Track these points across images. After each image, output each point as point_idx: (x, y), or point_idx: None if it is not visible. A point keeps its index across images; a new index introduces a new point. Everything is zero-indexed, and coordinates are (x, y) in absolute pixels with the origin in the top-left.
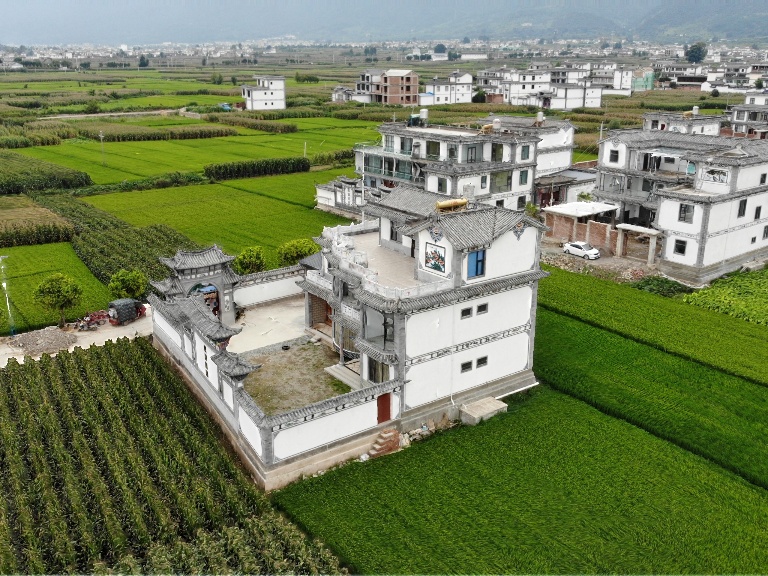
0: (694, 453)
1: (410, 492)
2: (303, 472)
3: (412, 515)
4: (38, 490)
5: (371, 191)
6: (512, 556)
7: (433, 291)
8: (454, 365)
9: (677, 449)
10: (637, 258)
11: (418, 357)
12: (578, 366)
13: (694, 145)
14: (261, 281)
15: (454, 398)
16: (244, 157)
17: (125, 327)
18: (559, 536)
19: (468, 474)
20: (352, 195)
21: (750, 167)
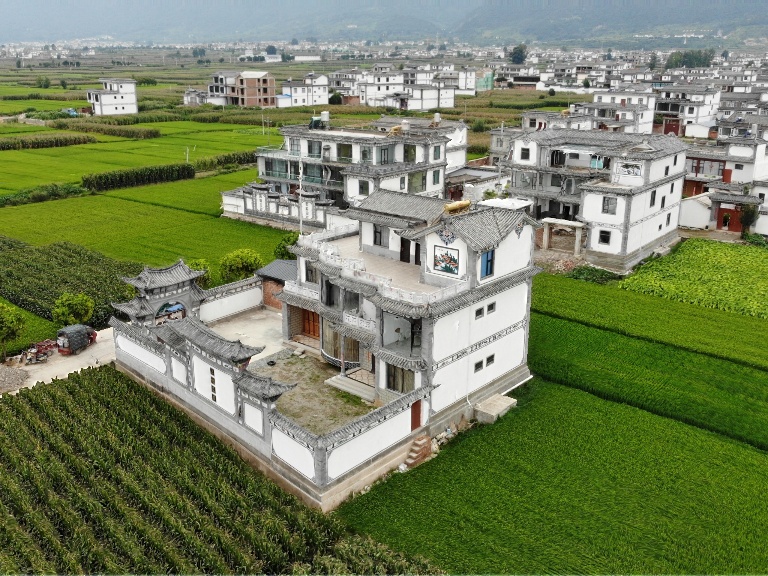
0: (699, 427)
1: (469, 496)
2: (352, 490)
3: (483, 519)
4: (82, 546)
5: (287, 196)
6: (596, 545)
7: (454, 294)
8: (469, 366)
9: (684, 425)
10: (562, 250)
11: (442, 361)
12: (560, 356)
13: (598, 141)
14: (221, 296)
15: (469, 398)
16: (117, 165)
17: (78, 356)
18: (626, 520)
19: (514, 471)
20: (265, 201)
21: (658, 160)
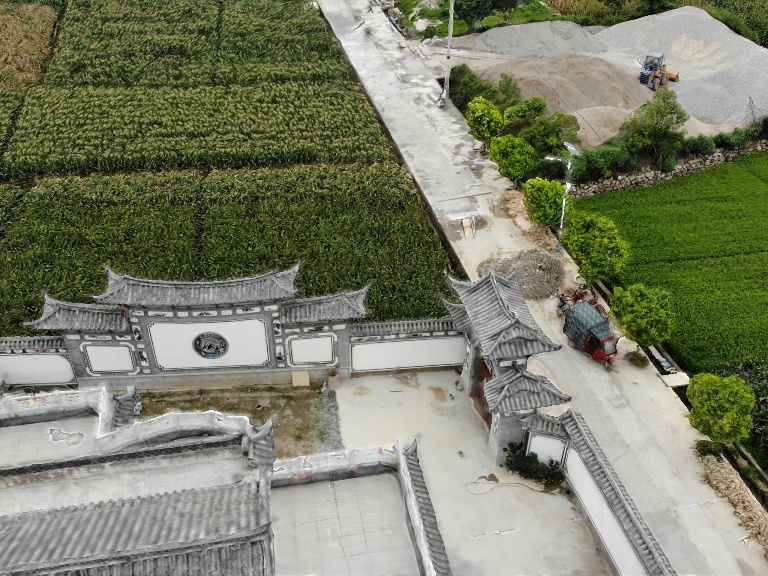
0: None
1: None
2: None
3: None
4: None
5: None
6: None
7: None
8: None
9: None
10: None
11: None
12: None
13: None
14: None
15: None
16: None
17: None
18: None
19: None
20: None
21: None
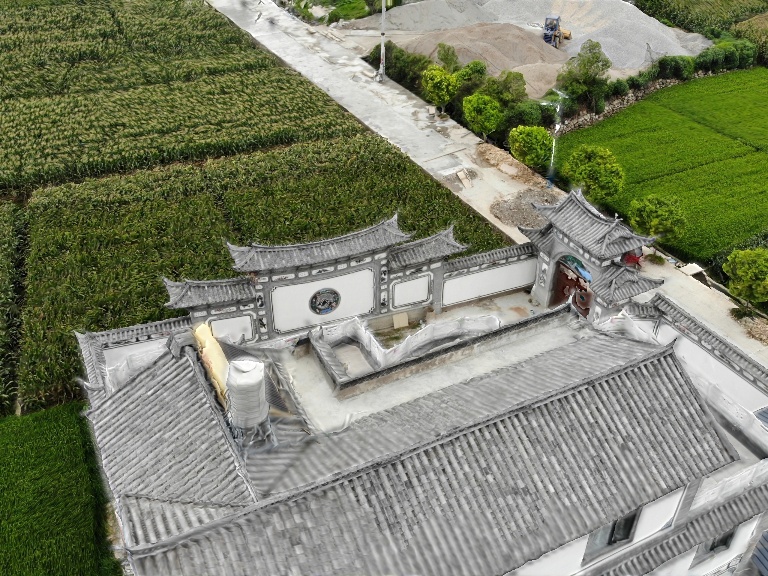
0: None
1: None
2: None
3: None
4: None
5: None
6: None
7: None
8: None
9: None
10: None
11: None
12: None
13: None
14: (712, 350)
15: None
16: None
17: None
18: None
19: None
20: None
21: None
